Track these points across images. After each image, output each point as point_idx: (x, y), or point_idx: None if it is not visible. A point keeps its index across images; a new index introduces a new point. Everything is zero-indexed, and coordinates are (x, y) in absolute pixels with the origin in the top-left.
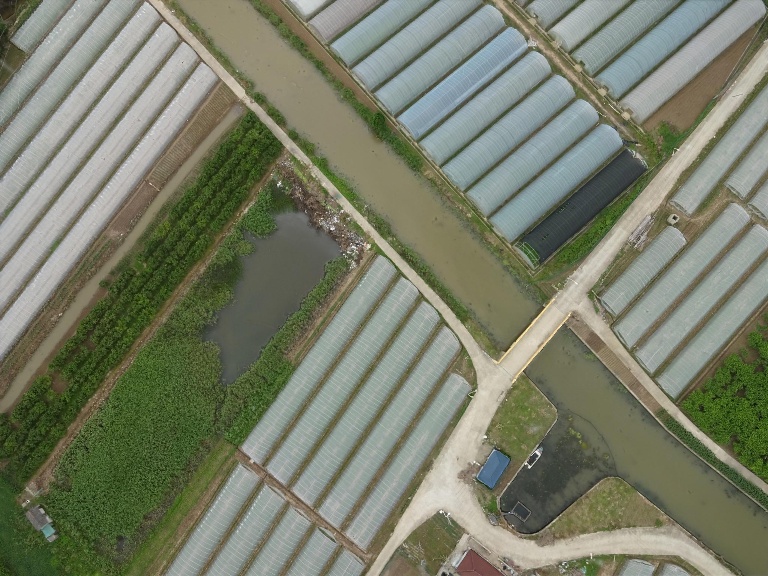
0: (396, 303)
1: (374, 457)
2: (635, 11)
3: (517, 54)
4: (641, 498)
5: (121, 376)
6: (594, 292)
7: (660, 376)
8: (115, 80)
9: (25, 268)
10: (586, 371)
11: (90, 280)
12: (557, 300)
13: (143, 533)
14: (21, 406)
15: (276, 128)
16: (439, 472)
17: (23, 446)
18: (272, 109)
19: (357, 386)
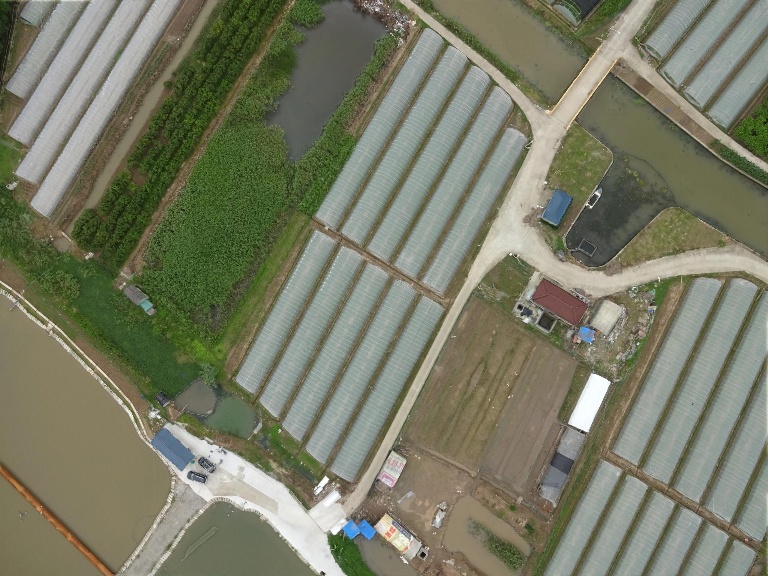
0: (447, 69)
1: (442, 209)
2: None
3: None
4: (702, 223)
5: (195, 163)
6: (637, 39)
7: (710, 109)
8: None
9: (93, 77)
10: (637, 115)
11: (154, 85)
12: (602, 50)
13: (234, 301)
14: (107, 199)
15: None
16: (505, 219)
17: (113, 234)
18: None
19: (418, 151)
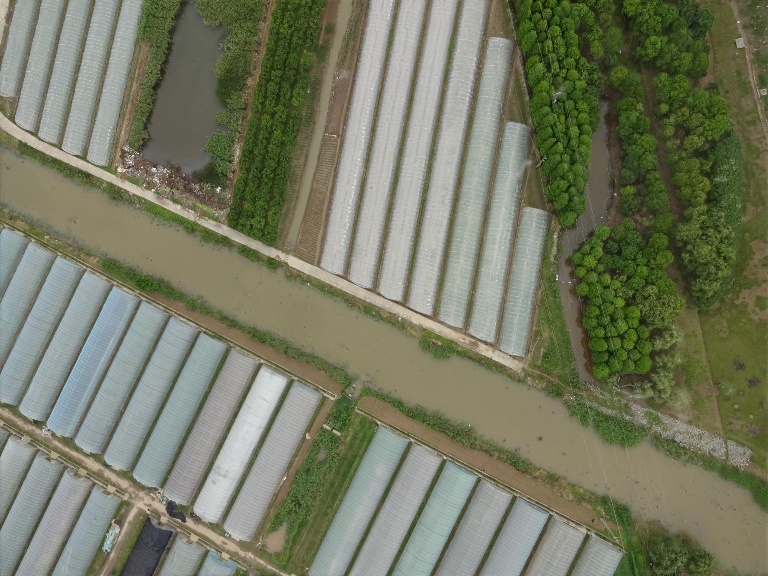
0: (74, 129)
1: (46, 1)
2: None
3: None
4: None
5: None
6: None
7: None
8: (419, 220)
9: (404, 4)
10: None
11: None
12: None
13: None
14: None
15: (244, 241)
16: None
17: None
18: (252, 256)
19: None
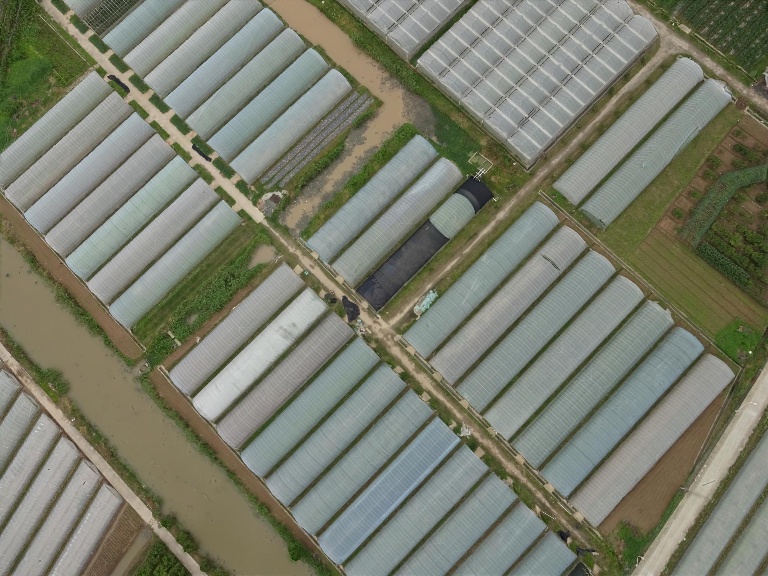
0: None
1: None
2: (580, 391)
3: (448, 451)
4: None
5: None
6: None
7: None
8: (14, 509)
9: None
10: None
11: None
12: None
13: None
14: None
15: (187, 558)
16: None
17: None
18: (180, 538)
19: None
